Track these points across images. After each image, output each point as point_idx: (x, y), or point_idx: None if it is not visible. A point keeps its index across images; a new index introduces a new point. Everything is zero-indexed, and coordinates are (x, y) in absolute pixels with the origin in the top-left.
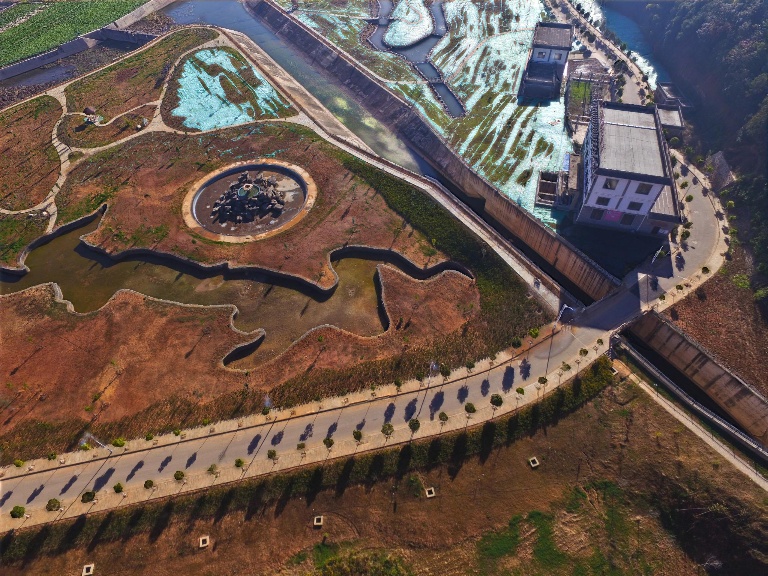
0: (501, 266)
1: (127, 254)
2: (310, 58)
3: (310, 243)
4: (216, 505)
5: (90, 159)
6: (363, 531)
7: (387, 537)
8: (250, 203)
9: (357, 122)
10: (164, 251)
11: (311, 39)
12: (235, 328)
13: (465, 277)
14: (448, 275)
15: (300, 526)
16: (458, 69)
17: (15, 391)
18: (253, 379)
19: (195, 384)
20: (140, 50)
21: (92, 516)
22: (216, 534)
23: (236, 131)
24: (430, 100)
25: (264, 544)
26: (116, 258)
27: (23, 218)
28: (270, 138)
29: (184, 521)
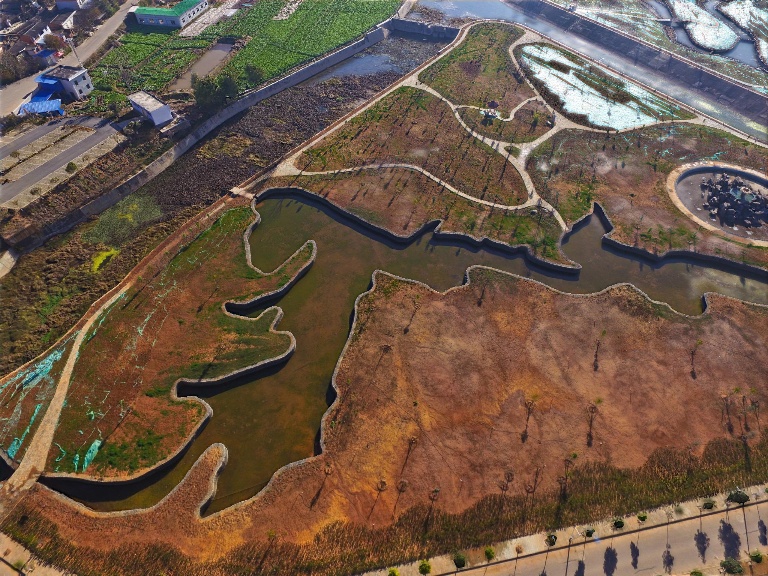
0: None
1: (666, 255)
2: (630, 58)
3: None
4: None
5: (533, 155)
6: None
7: None
8: (752, 207)
9: (743, 126)
10: (710, 254)
11: (622, 39)
12: None
13: None
14: None
15: None
16: None
17: (718, 396)
18: None
19: None
20: (457, 43)
21: None
22: None
23: (654, 131)
24: None
25: None
26: (659, 259)
27: (527, 214)
28: (696, 140)
29: None
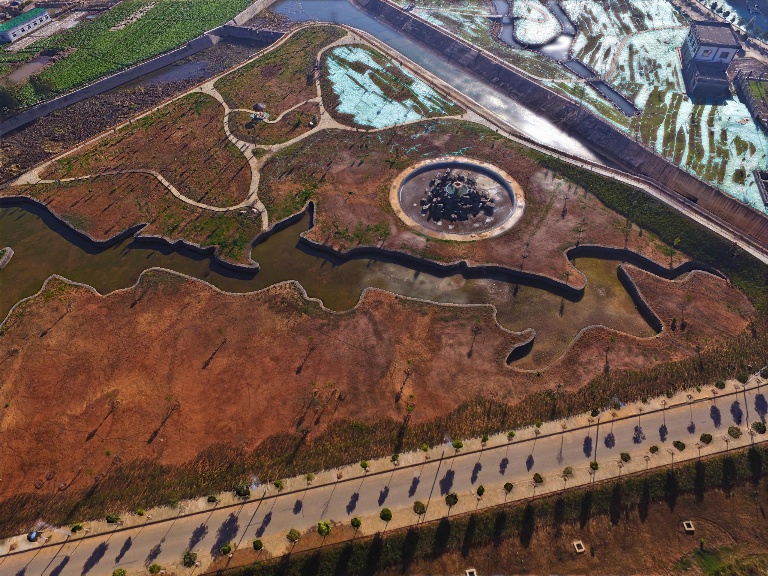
0: (759, 266)
1: (353, 252)
2: (445, 56)
3: (541, 242)
4: (577, 509)
5: (276, 156)
6: (738, 537)
7: (766, 543)
8: (462, 201)
9: (521, 120)
10: (394, 249)
11: (442, 37)
12: (503, 328)
13: (717, 277)
14: (699, 275)
15: (672, 531)
16: (612, 67)
17: (310, 390)
18: (549, 380)
19: (492, 384)
20: (273, 47)
21: (455, 519)
22: (588, 539)
23: (412, 128)
24: (596, 98)
25: (642, 549)
26: (344, 256)
27: (234, 215)
28: (450, 136)
29: (549, 525)
